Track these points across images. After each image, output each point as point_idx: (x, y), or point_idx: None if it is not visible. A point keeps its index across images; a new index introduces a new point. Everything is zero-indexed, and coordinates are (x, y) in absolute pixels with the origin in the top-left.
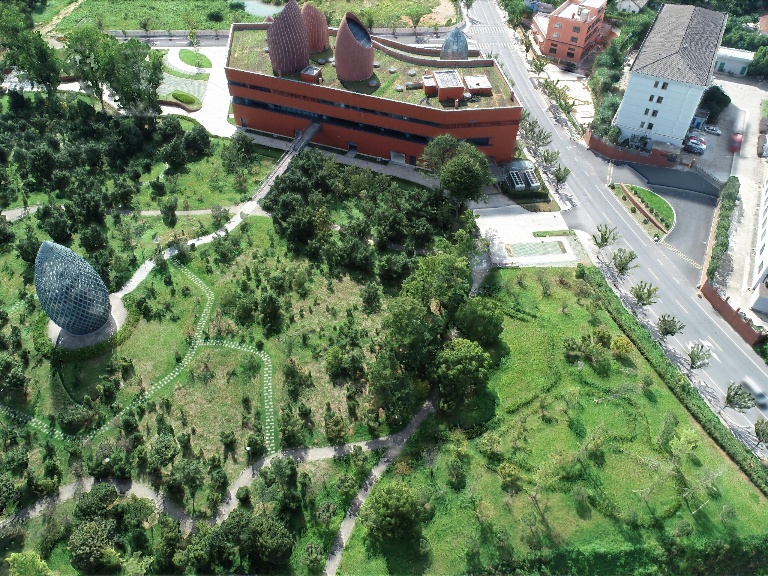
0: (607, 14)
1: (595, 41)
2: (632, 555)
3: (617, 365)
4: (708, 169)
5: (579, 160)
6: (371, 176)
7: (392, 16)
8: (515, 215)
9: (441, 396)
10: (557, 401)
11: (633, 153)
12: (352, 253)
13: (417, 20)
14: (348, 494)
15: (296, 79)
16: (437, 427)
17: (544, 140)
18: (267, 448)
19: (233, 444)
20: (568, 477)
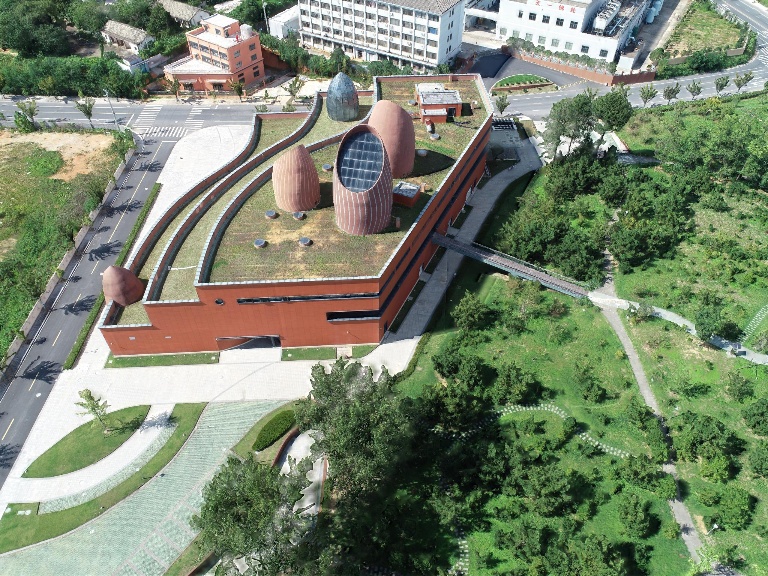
0: None
1: None
2: None
3: None
4: None
5: None
6: None
7: (50, 185)
8: None
9: None
10: (766, 135)
11: None
12: None
13: None
14: None
15: (406, 212)
16: None
17: None
18: None
19: None
20: None
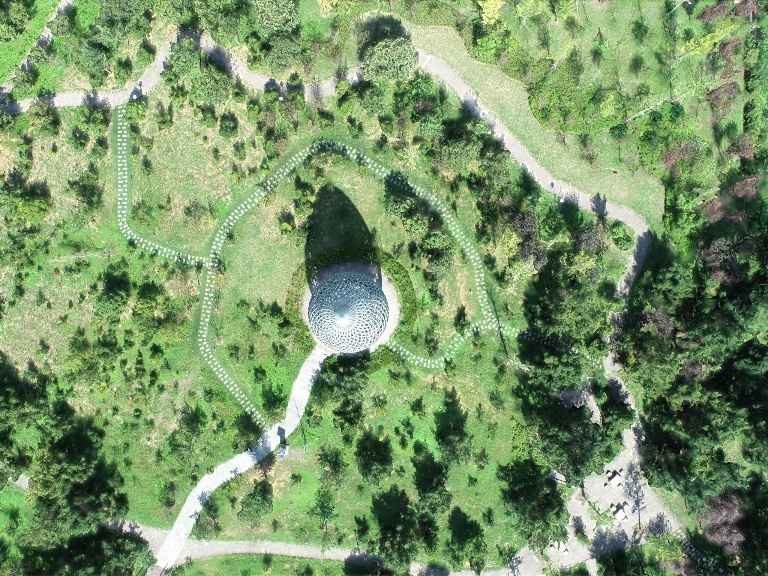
0: None
1: None
2: None
3: None
4: None
5: None
6: None
7: None
8: None
9: None
10: None
11: None
12: None
13: None
14: None
15: None
16: None
17: None
18: None
19: None
20: None
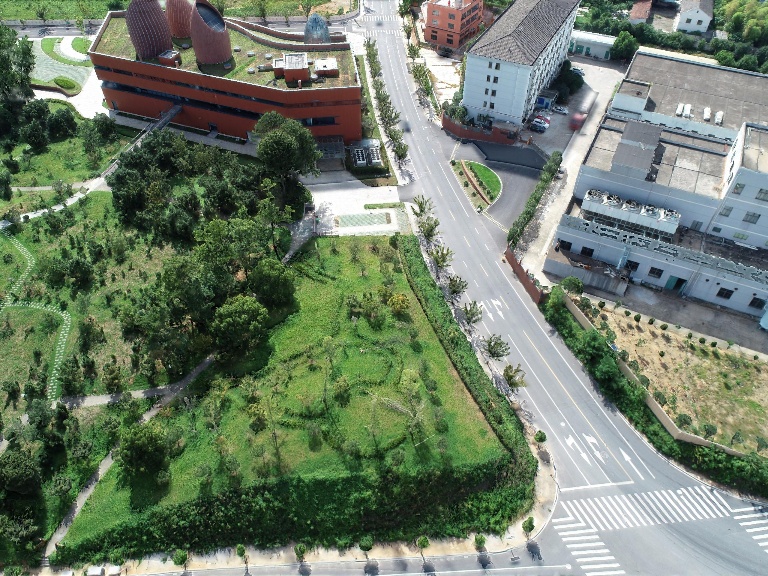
0: (488, 2)
1: (478, 28)
2: (349, 481)
3: (391, 320)
4: (545, 146)
5: (430, 139)
6: (218, 154)
7: (290, 5)
8: (353, 189)
9: (218, 348)
10: None
11: (478, 131)
12: (175, 223)
13: (308, 9)
14: (115, 436)
15: (156, 63)
16: (213, 376)
17: (395, 120)
18: (48, 396)
19: (16, 393)
20: (310, 416)
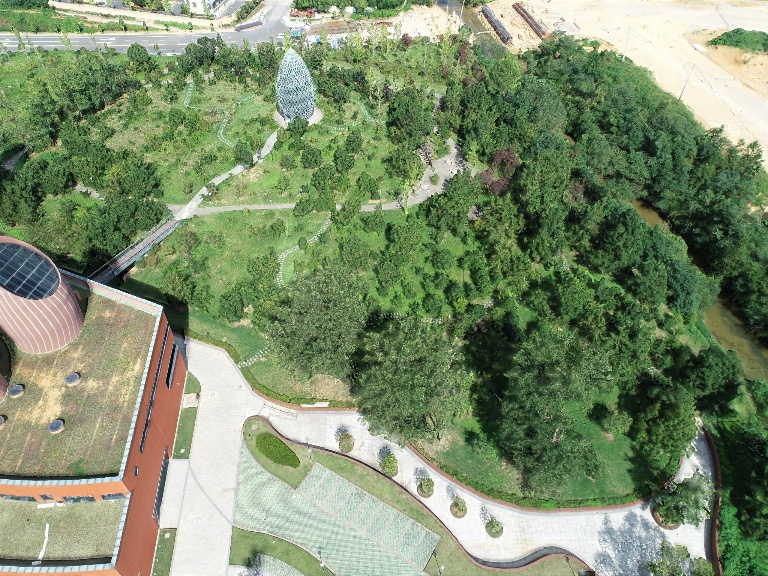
0: None
1: None
2: None
3: None
4: None
5: None
6: None
7: None
8: None
9: None
10: None
11: None
12: None
13: None
14: None
15: None
16: None
17: None
18: None
19: None
20: None
